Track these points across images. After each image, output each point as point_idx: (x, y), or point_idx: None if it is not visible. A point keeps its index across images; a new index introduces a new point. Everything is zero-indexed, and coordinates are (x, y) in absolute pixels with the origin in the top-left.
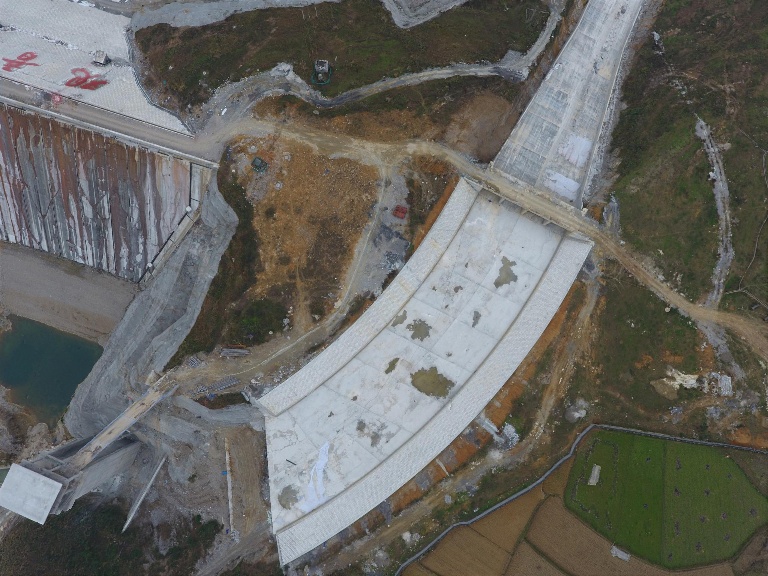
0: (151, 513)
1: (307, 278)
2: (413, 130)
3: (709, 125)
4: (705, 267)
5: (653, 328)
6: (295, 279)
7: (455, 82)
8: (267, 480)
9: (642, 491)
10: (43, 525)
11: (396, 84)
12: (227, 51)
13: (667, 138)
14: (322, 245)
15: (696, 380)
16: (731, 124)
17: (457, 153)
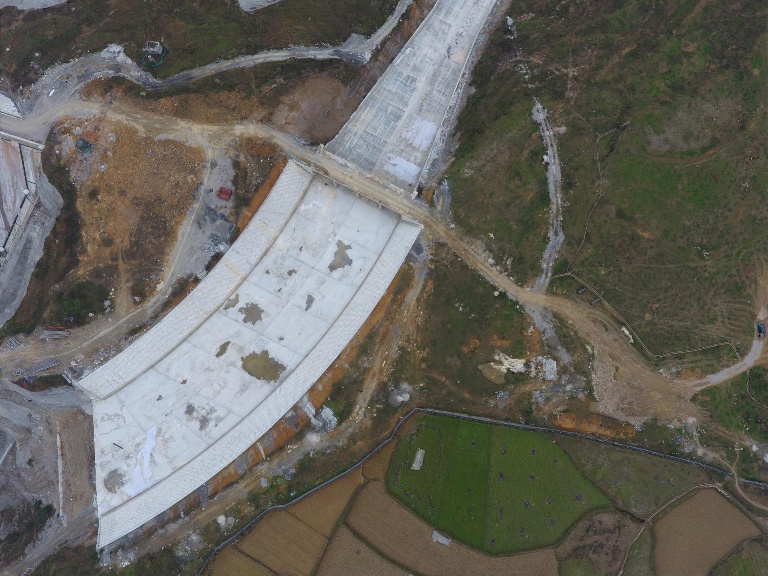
0: None
1: (130, 260)
2: (241, 112)
3: (546, 108)
4: (535, 251)
5: (481, 312)
6: (117, 261)
7: (289, 64)
8: None
9: (466, 476)
10: None
11: (230, 66)
12: (61, 32)
13: (504, 121)
14: (146, 227)
15: (523, 364)
16: (569, 108)
17: (285, 135)
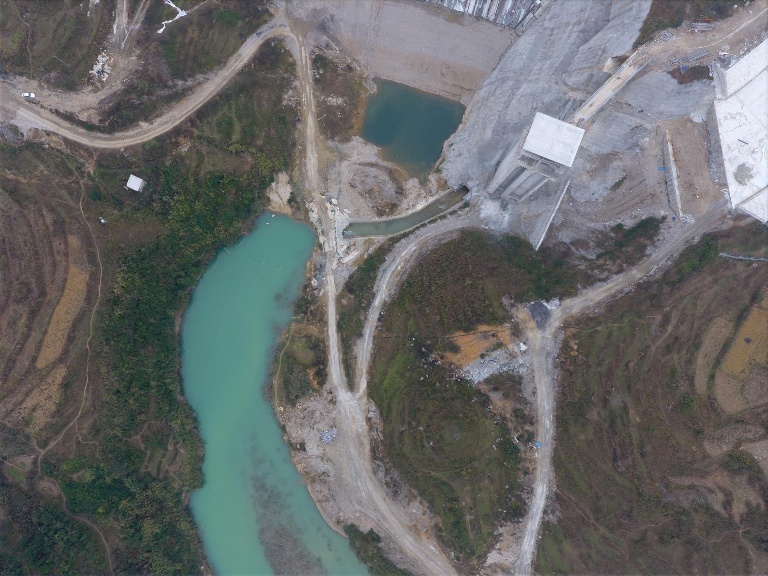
0: (558, 235)
1: None
2: None
3: None
4: None
5: None
6: None
7: None
8: (712, 166)
9: None
10: (467, 242)
11: None
12: None
13: None
14: None
15: None
16: None
17: None
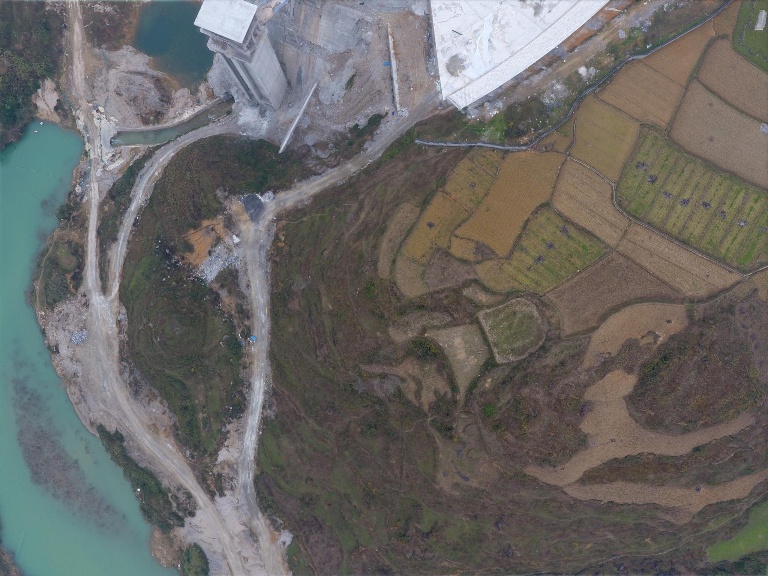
0: (305, 138)
1: None
2: None
3: None
4: None
5: None
6: None
7: None
8: (431, 60)
9: None
10: (206, 142)
11: None
12: None
13: None
14: None
15: None
16: None
17: None
